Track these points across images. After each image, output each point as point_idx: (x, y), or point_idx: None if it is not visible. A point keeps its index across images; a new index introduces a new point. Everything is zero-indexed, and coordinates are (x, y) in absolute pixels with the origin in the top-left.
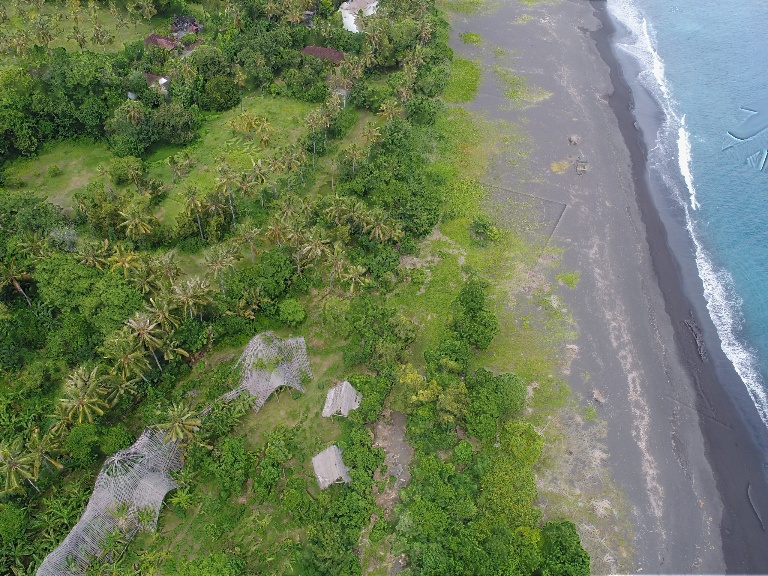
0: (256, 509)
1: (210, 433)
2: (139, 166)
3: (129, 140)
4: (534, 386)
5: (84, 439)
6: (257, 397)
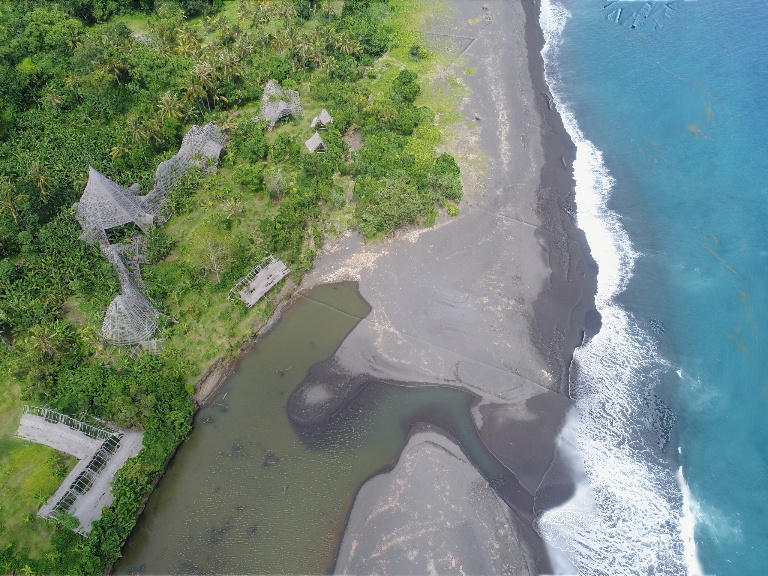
0: (273, 167)
1: (244, 131)
2: None
3: (173, 6)
4: (440, 114)
5: (173, 124)
6: (271, 120)
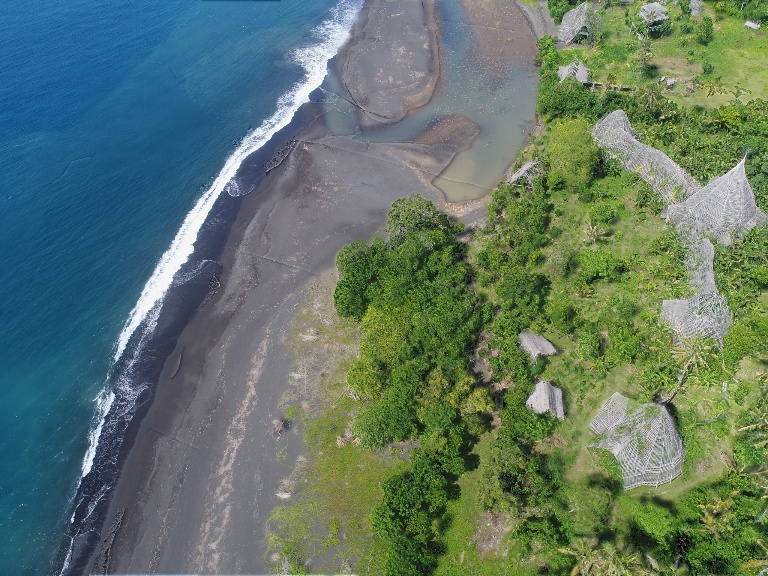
0: None
1: None
2: None
3: None
4: (342, 438)
5: None
6: None
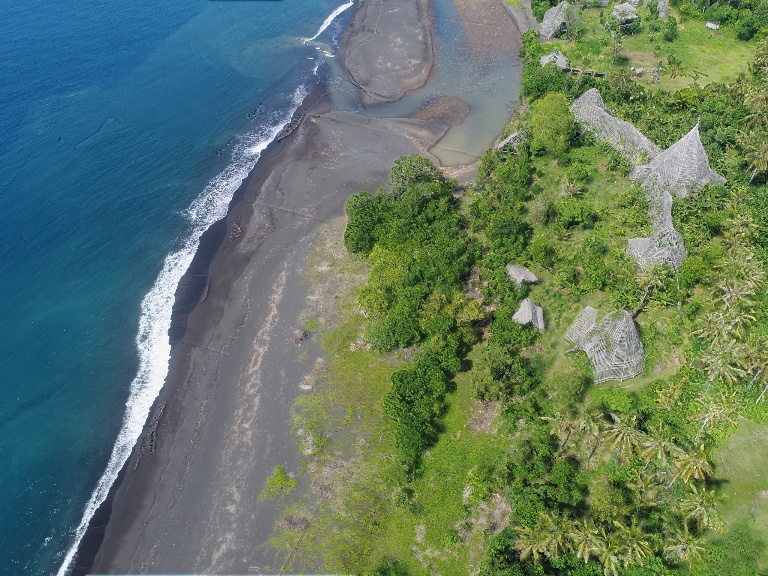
0: None
1: None
2: None
3: None
4: None
5: None
6: None
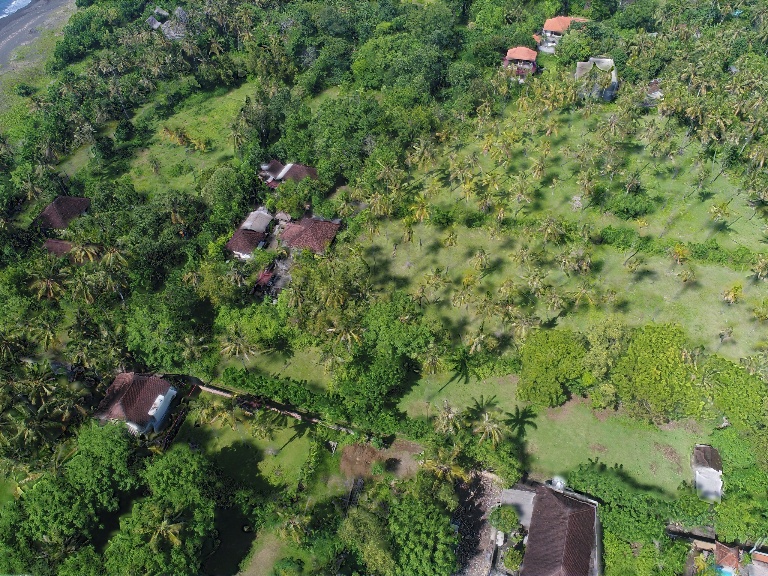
0: None
1: None
2: None
3: None
4: None
5: None
6: None
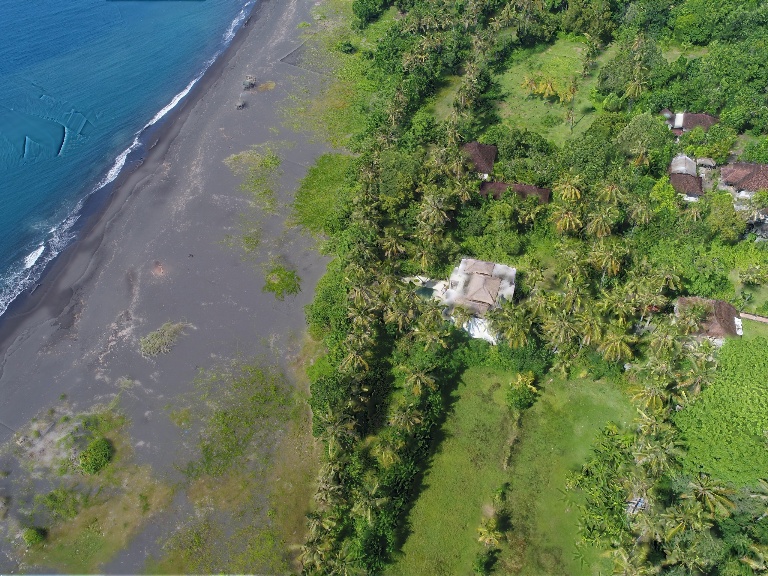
0: None
1: None
2: (616, 56)
3: None
4: None
5: None
6: None
